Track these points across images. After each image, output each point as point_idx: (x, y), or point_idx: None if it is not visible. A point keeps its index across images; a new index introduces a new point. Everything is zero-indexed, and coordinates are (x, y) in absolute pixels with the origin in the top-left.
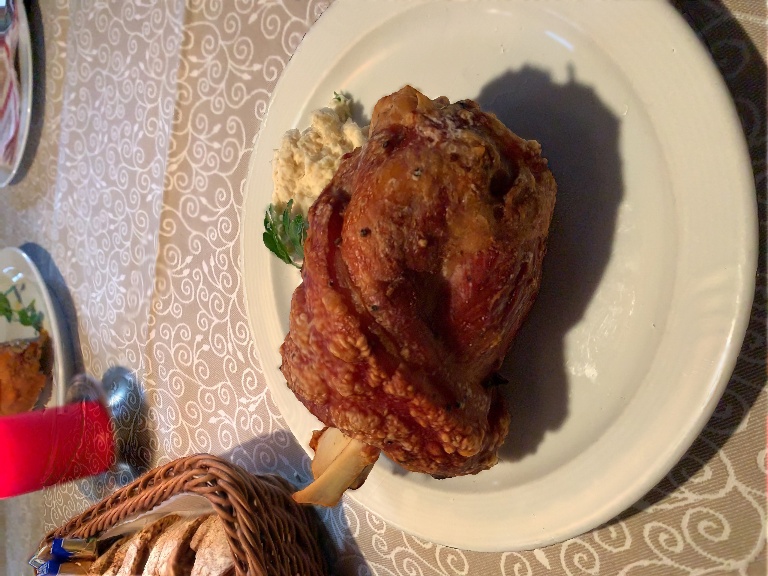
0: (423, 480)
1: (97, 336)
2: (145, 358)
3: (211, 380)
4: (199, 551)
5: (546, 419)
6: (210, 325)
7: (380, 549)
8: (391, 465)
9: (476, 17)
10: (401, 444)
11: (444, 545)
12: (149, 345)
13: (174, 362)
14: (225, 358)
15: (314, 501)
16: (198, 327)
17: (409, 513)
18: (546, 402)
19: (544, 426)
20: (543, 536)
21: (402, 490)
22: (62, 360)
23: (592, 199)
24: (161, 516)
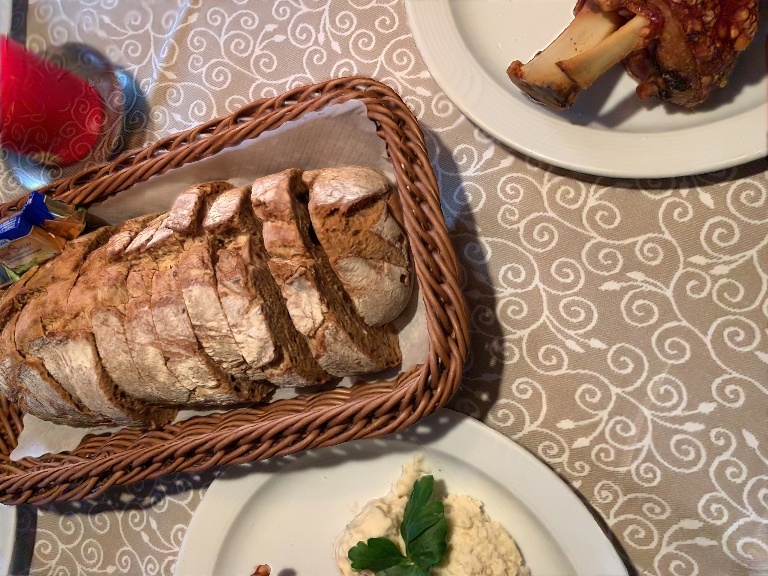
0: (607, 129)
1: (69, 24)
2: (171, 44)
3: (277, 73)
4: (320, 183)
5: (746, 76)
6: (294, 14)
7: (507, 219)
8: (567, 120)
9: None
10: (705, 12)
11: (631, 176)
12: (183, 30)
13: (222, 50)
14: (309, 49)
15: (577, 72)
16: (272, 15)
17: (592, 153)
18: (749, 63)
19: (743, 82)
20: (751, 150)
21: (584, 136)
22: (6, 39)
23: None
24: (217, 179)
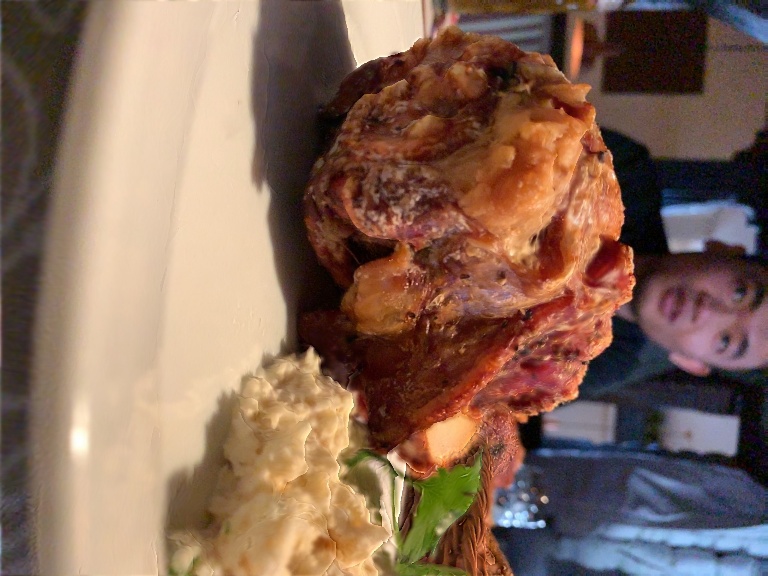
0: None
1: None
2: None
3: None
4: None
5: None
6: None
7: None
8: None
9: (214, 12)
10: None
11: None
12: None
13: None
14: None
15: None
16: None
17: None
18: None
19: None
20: None
21: None
22: None
23: (340, 48)
24: None
